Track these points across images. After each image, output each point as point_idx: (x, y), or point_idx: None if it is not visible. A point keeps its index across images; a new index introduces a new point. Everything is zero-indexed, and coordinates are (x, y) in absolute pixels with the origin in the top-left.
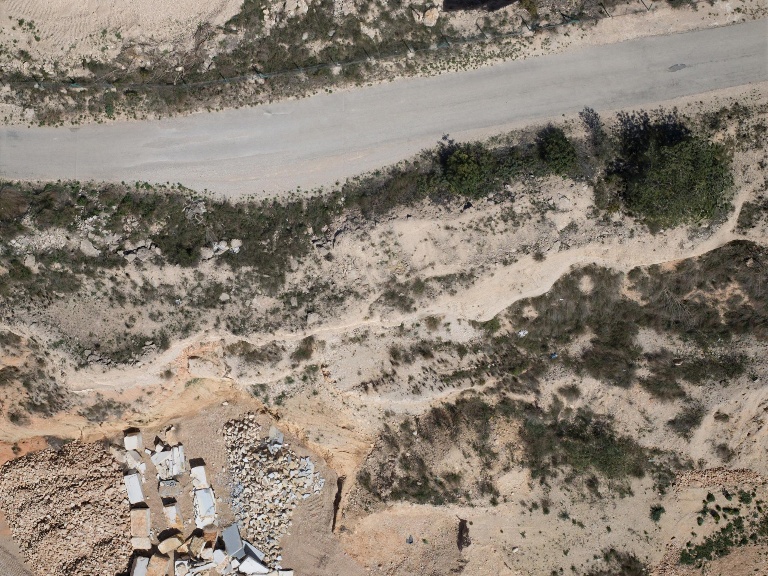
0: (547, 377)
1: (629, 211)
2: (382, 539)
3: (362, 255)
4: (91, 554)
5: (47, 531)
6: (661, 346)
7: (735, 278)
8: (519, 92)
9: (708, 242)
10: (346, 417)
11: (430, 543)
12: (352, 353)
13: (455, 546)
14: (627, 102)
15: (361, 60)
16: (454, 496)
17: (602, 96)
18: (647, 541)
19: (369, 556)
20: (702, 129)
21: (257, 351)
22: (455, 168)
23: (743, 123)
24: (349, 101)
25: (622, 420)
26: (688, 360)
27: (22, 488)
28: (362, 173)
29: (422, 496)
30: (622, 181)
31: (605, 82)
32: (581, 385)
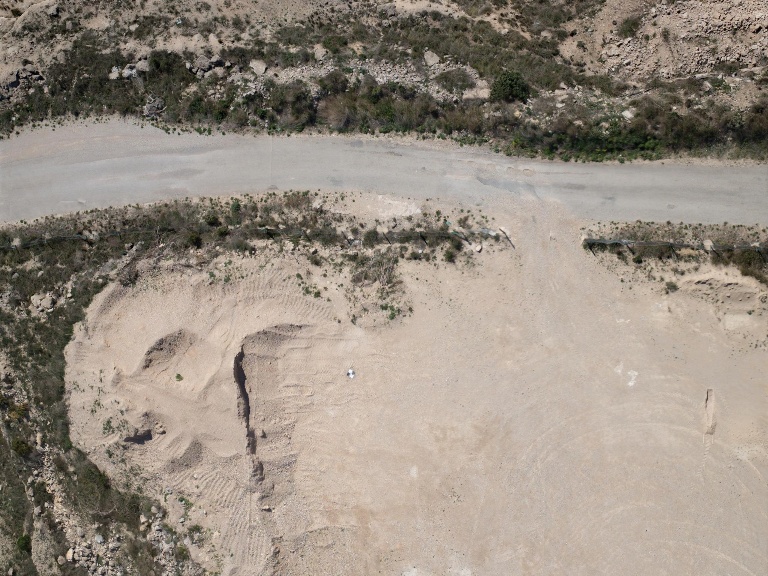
0: None
1: None
2: None
3: None
4: None
5: None
6: None
7: None
8: None
9: None
10: None
11: None
12: None
13: None
14: None
15: None
16: None
17: None
18: None
19: None
20: None
21: None
22: None
23: None
24: (5, 212)
25: None
26: None
27: None
28: None
29: None
30: None
31: None
32: None
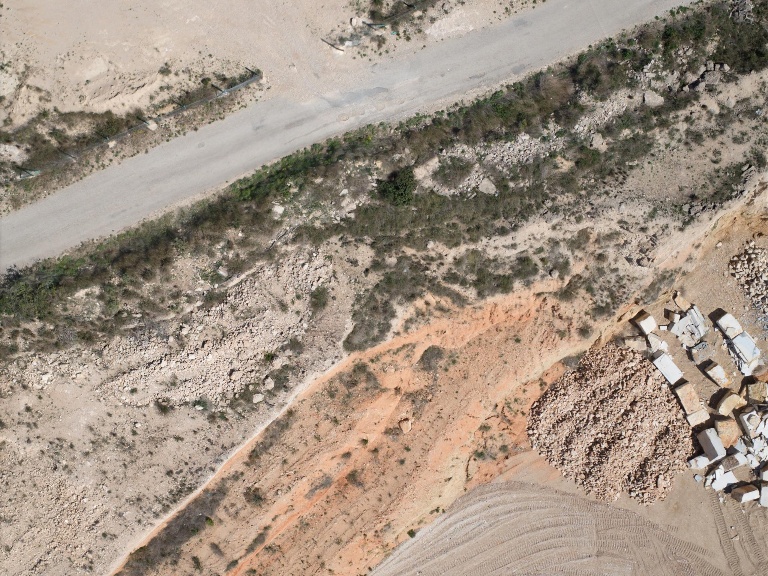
0: None
1: None
2: None
3: None
4: (653, 453)
5: (608, 449)
6: None
7: None
8: None
9: None
10: None
11: None
12: None
13: None
14: None
15: None
16: None
17: None
18: None
19: None
20: None
21: None
22: None
23: None
24: None
25: None
26: None
27: (561, 421)
28: None
29: None
30: None
31: None
32: None
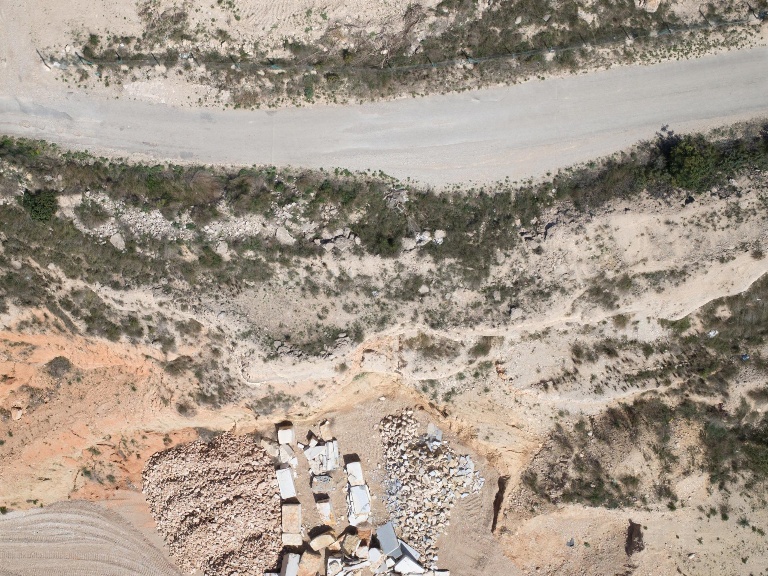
0: (738, 379)
1: None
2: (543, 541)
3: (574, 249)
4: (239, 549)
5: (197, 525)
6: None
7: None
8: (744, 83)
9: None
10: (517, 415)
11: (593, 547)
12: (531, 350)
13: (622, 550)
14: None
15: (577, 46)
16: (630, 499)
17: None
18: None
19: (528, 558)
20: None
21: (435, 346)
22: (680, 160)
23: None
24: (563, 89)
25: None
26: None
27: (171, 480)
28: (575, 164)
29: (596, 499)
30: None
31: None
32: None
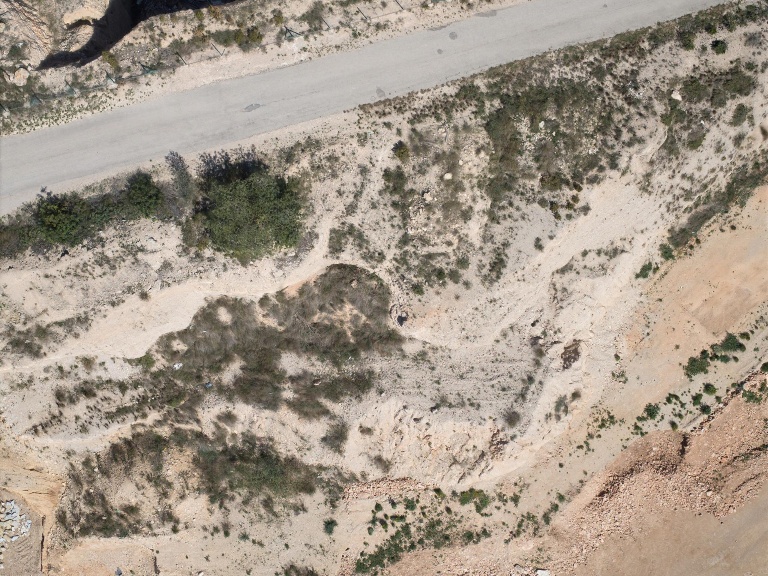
0: (203, 406)
1: (217, 246)
2: (91, 574)
3: None
4: None
5: None
6: (302, 368)
7: (347, 299)
8: (108, 142)
9: (300, 269)
10: (32, 459)
11: (137, 573)
12: (22, 398)
13: (154, 575)
14: (208, 144)
15: None
16: (137, 527)
17: (185, 140)
18: (323, 554)
19: None
20: (279, 164)
21: None
22: None
23: (315, 155)
24: None
25: (281, 441)
26: (326, 379)
27: None
28: None
29: (107, 530)
30: (206, 219)
31: (187, 126)
32: (236, 411)
